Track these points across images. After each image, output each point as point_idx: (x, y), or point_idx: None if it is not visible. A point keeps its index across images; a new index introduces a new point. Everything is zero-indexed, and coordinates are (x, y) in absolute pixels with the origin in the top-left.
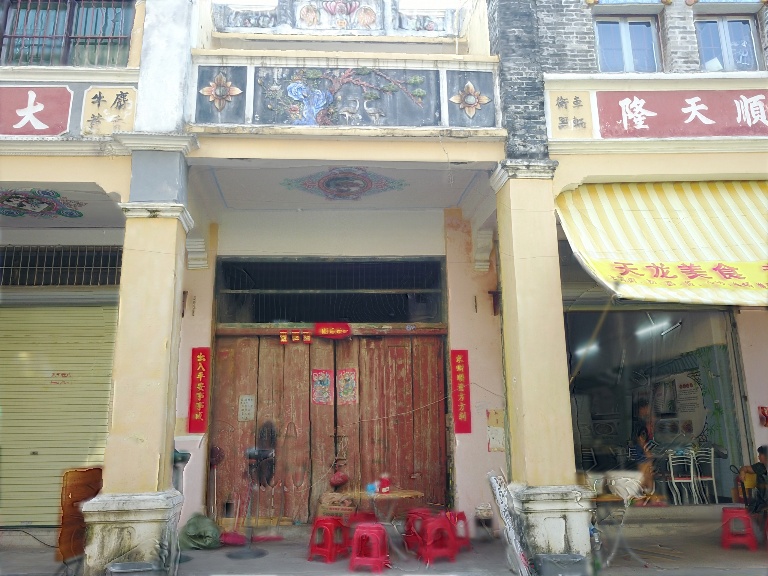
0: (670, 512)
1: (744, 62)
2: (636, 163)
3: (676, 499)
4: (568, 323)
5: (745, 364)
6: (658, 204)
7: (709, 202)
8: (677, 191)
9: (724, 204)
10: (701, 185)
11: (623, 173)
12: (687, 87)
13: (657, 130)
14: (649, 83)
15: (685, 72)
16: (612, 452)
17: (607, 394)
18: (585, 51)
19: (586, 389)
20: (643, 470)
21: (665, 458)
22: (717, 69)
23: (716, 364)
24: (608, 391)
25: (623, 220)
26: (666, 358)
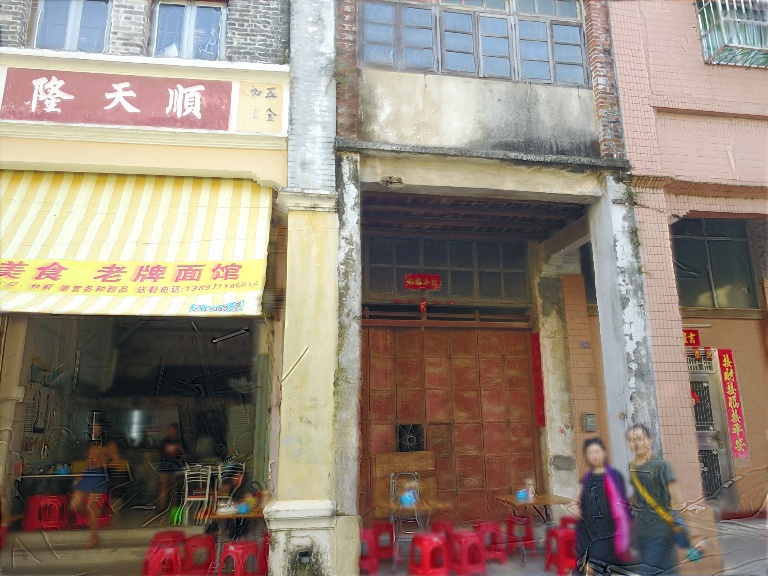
0: (163, 534)
1: (209, 51)
2: (38, 149)
3: (177, 519)
4: (103, 327)
5: (275, 375)
6: (62, 196)
7: (122, 197)
8: (97, 183)
9: (136, 200)
10: (129, 179)
11: (20, 159)
12: (117, 71)
13: (69, 114)
14: (70, 63)
15: (120, 54)
16: (152, 467)
17: (145, 405)
18: (7, 22)
19: (122, 399)
20: (170, 487)
21: (184, 474)
22: (173, 56)
23: (260, 374)
24: (146, 401)
25: (1, 211)
26: (230, 367)
